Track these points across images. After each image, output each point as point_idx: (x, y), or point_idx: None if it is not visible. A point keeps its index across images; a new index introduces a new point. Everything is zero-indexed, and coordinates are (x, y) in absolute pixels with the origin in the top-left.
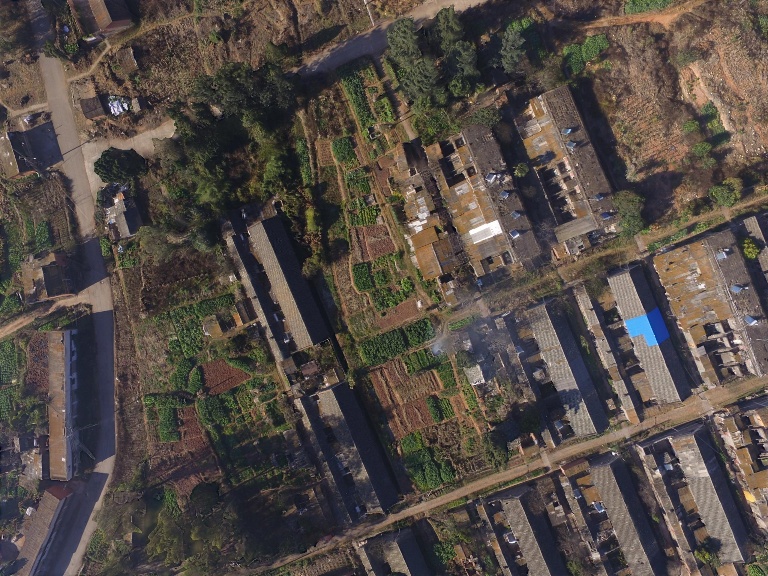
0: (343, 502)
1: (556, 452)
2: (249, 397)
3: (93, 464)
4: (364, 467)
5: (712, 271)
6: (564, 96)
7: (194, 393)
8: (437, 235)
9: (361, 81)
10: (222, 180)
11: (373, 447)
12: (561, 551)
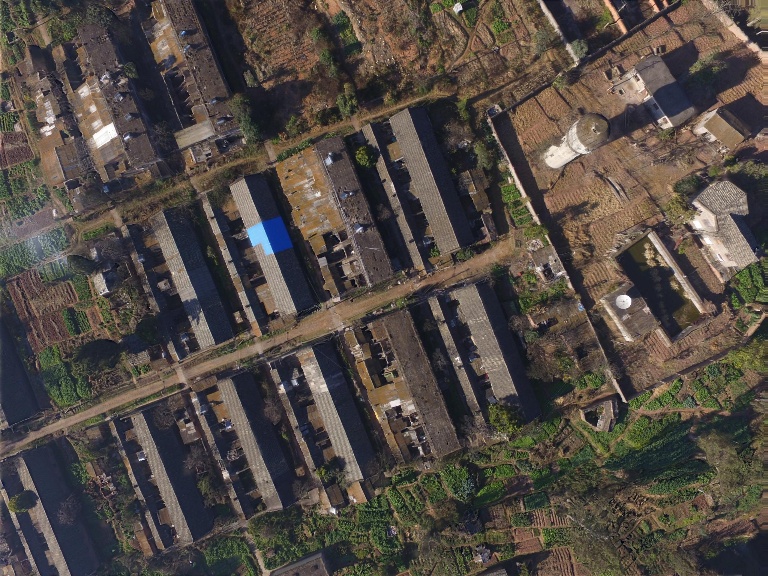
0: None
1: (191, 368)
2: None
3: None
4: None
5: (323, 177)
6: None
7: None
8: (62, 140)
9: None
10: None
11: (6, 360)
12: None
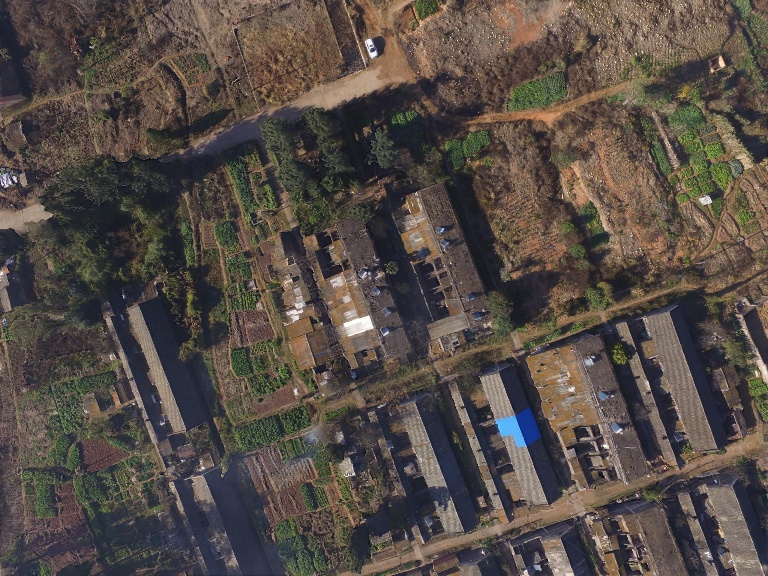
0: None
1: (429, 546)
2: (127, 475)
3: None
4: (234, 555)
5: (581, 376)
6: (439, 194)
7: (72, 470)
8: (312, 326)
9: (245, 166)
10: (105, 259)
11: (246, 533)
12: None
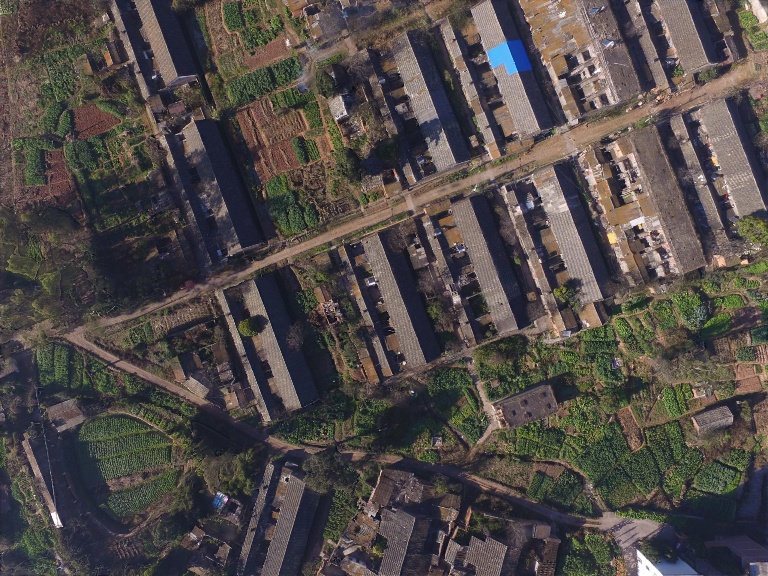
0: (203, 242)
1: (421, 195)
2: (118, 142)
3: None
4: (224, 202)
5: None
6: None
7: (63, 136)
8: None
9: None
10: None
11: (236, 186)
12: None
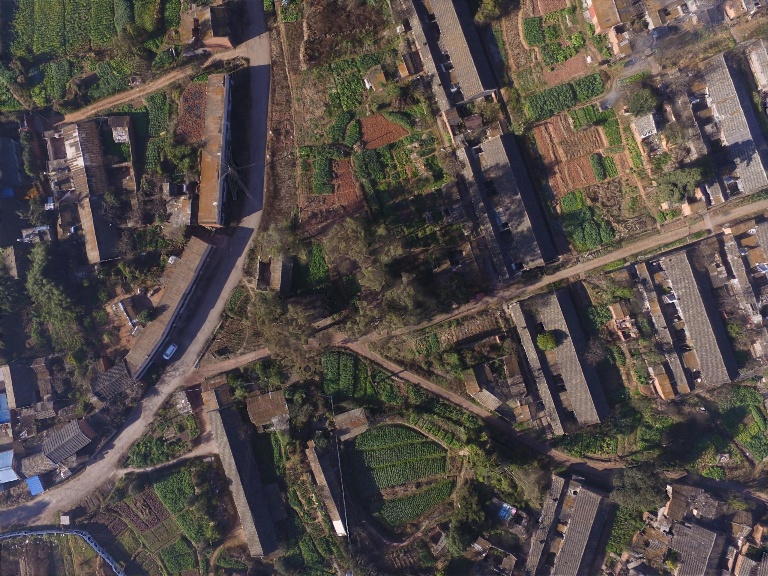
0: (501, 255)
1: (719, 215)
2: (406, 153)
3: (239, 218)
4: (527, 216)
5: None
6: None
7: (351, 145)
8: None
9: None
10: None
11: (534, 201)
12: None
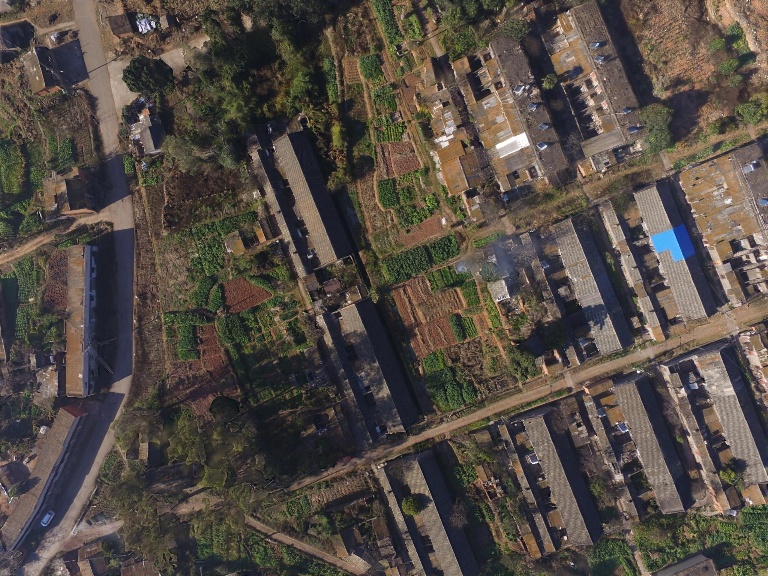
0: (363, 421)
1: (580, 372)
2: (270, 316)
3: (109, 384)
4: (386, 384)
5: (739, 185)
6: (592, 11)
7: (214, 311)
8: (463, 149)
9: None
10: (248, 96)
11: (395, 365)
12: (584, 471)
